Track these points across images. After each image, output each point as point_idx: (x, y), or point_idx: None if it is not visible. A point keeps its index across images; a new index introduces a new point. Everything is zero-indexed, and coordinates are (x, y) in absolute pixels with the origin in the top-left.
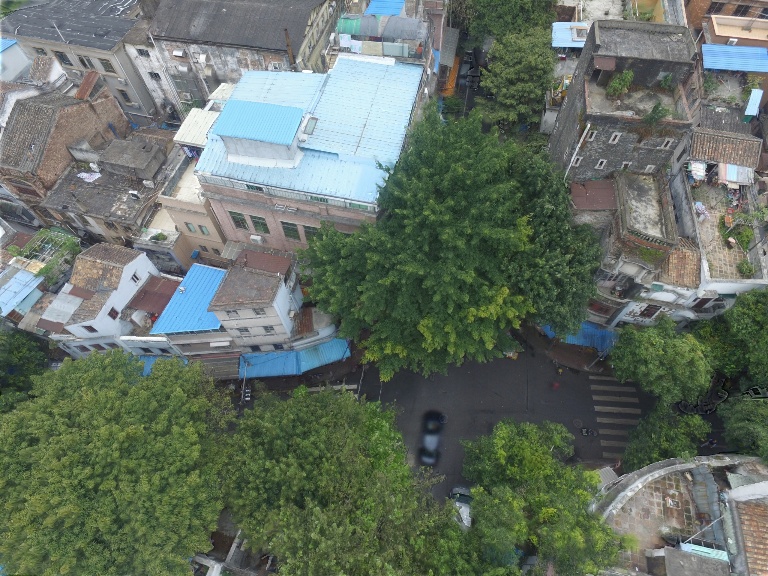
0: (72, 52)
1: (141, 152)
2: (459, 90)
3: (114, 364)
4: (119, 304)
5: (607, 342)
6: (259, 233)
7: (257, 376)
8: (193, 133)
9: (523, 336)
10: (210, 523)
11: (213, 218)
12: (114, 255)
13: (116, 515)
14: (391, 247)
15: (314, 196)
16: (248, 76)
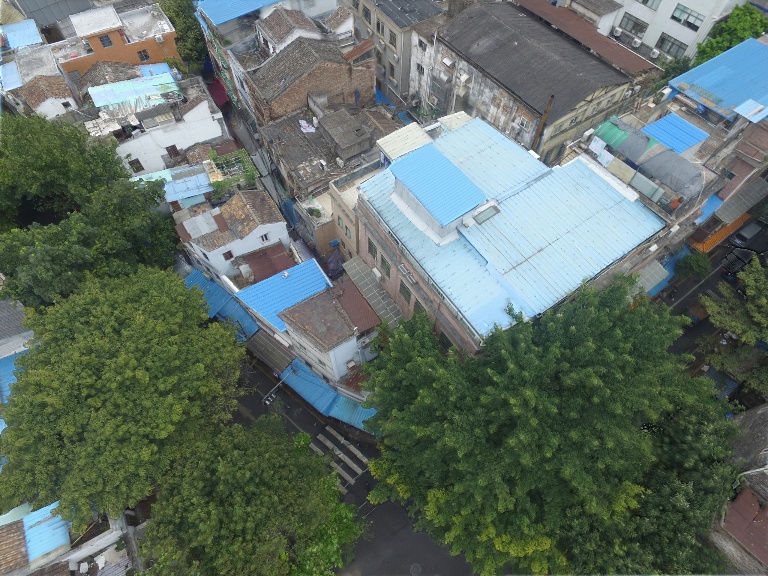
0: (375, 14)
1: (353, 133)
2: (709, 260)
3: (188, 302)
4: (237, 251)
5: None
6: (382, 271)
7: (293, 387)
8: (396, 146)
9: None
10: (133, 498)
11: None
12: (263, 209)
13: (82, 430)
14: (460, 396)
15: (435, 285)
16: (476, 125)
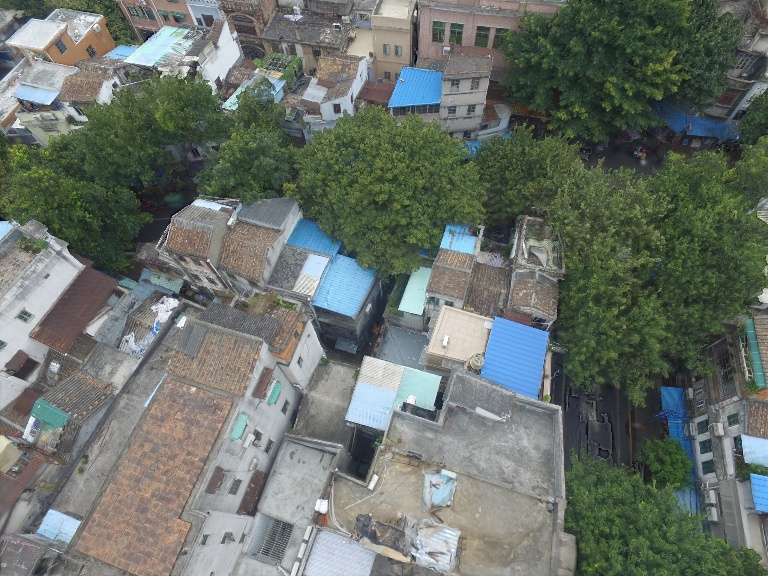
0: None
1: None
2: None
3: None
4: (354, 93)
5: (726, 131)
6: None
7: None
8: None
9: (647, 144)
10: (482, 196)
11: (410, 37)
12: (345, 58)
13: None
14: (589, 19)
15: None
16: None
